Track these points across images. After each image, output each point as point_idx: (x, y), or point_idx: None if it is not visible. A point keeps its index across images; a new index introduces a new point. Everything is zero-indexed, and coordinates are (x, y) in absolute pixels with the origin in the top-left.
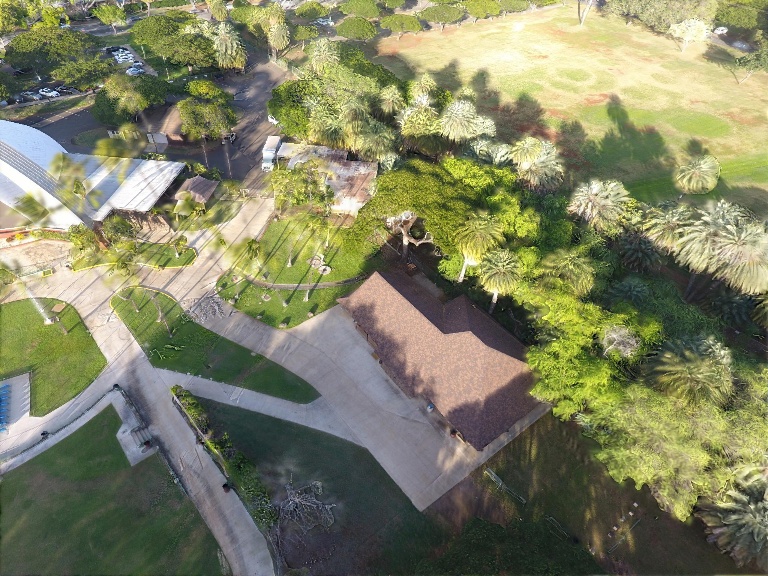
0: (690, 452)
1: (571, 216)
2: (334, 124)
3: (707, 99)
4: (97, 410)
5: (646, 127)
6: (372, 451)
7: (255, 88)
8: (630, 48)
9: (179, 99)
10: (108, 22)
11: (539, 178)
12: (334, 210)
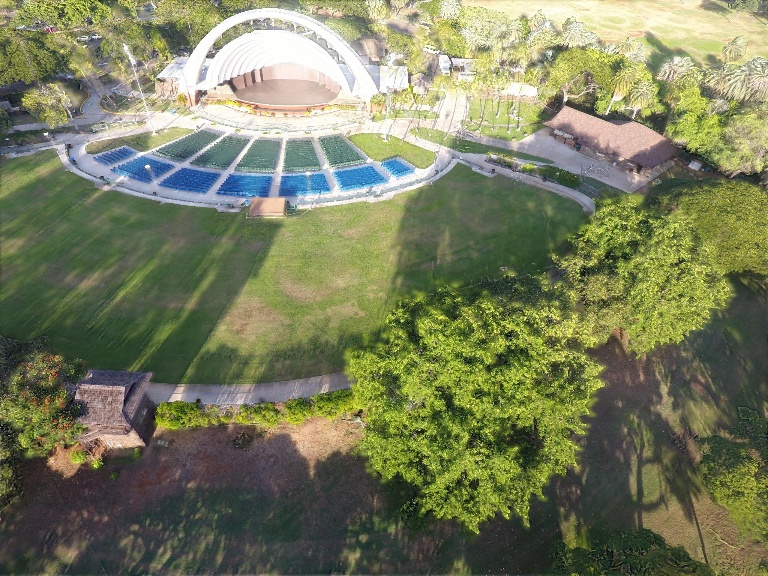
0: (765, 129)
1: None
2: (488, 43)
3: (711, 32)
4: (453, 164)
5: (676, 48)
6: (595, 178)
7: None
8: (646, 3)
9: (363, 36)
10: None
11: None
12: (503, 93)
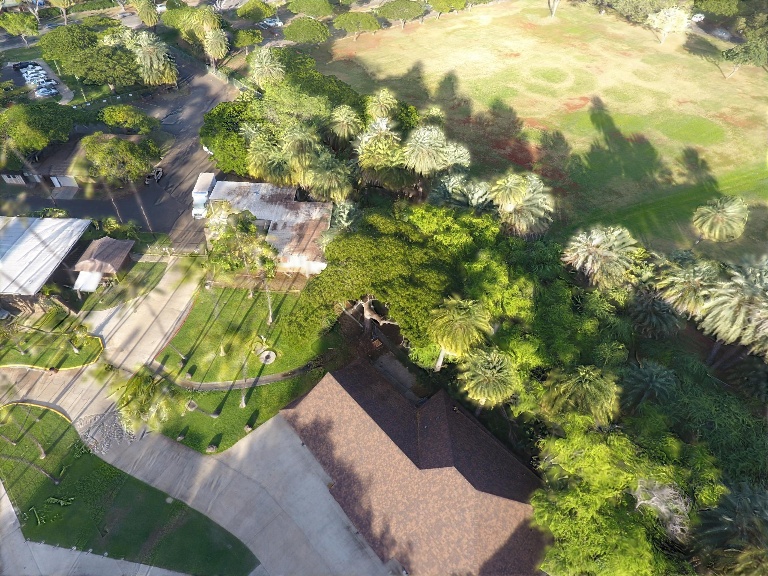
0: None
1: (566, 267)
2: (277, 157)
3: (695, 98)
4: None
5: (634, 136)
6: None
7: (190, 107)
8: (607, 41)
9: (92, 129)
10: (16, 32)
11: (525, 220)
12: (280, 268)
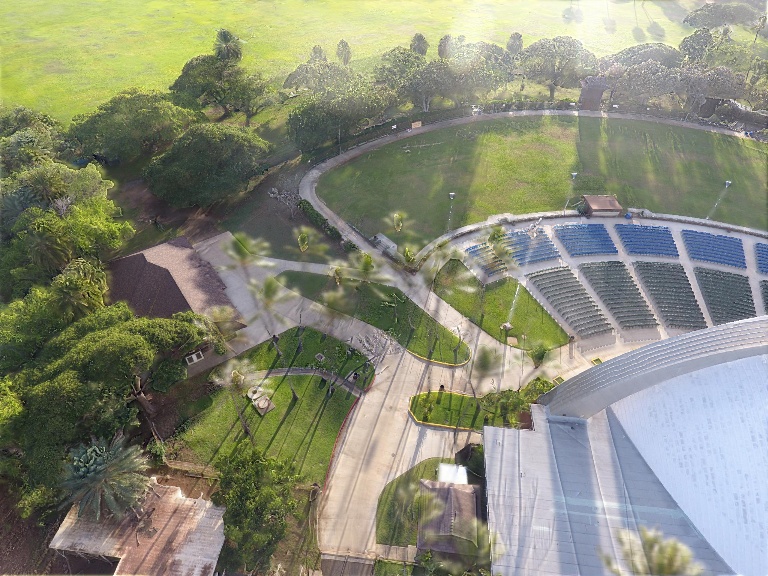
0: None
1: None
2: None
3: None
4: (417, 258)
5: None
6: (247, 252)
7: None
8: None
9: None
10: None
11: None
12: None
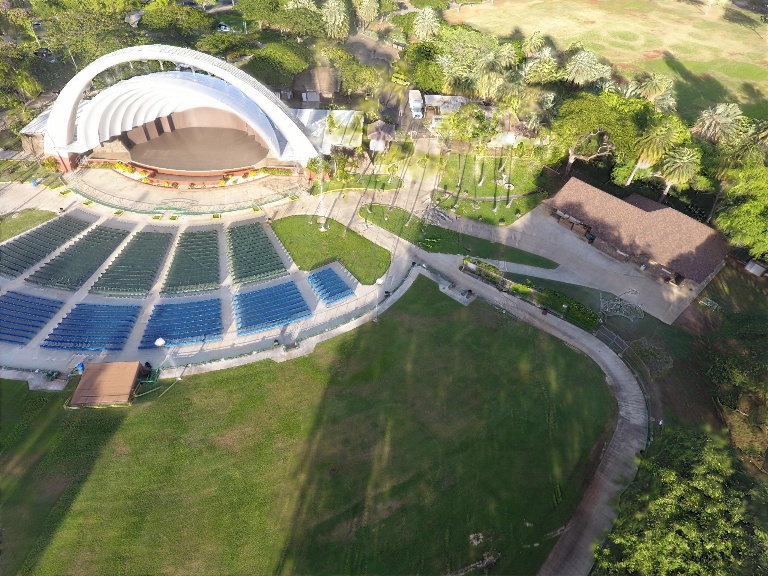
0: None
1: None
2: (471, 76)
3: (742, 51)
4: (413, 277)
5: (703, 75)
6: (616, 294)
7: (360, 55)
8: (661, 13)
9: None
10: (201, 2)
11: (660, 108)
12: (490, 145)
